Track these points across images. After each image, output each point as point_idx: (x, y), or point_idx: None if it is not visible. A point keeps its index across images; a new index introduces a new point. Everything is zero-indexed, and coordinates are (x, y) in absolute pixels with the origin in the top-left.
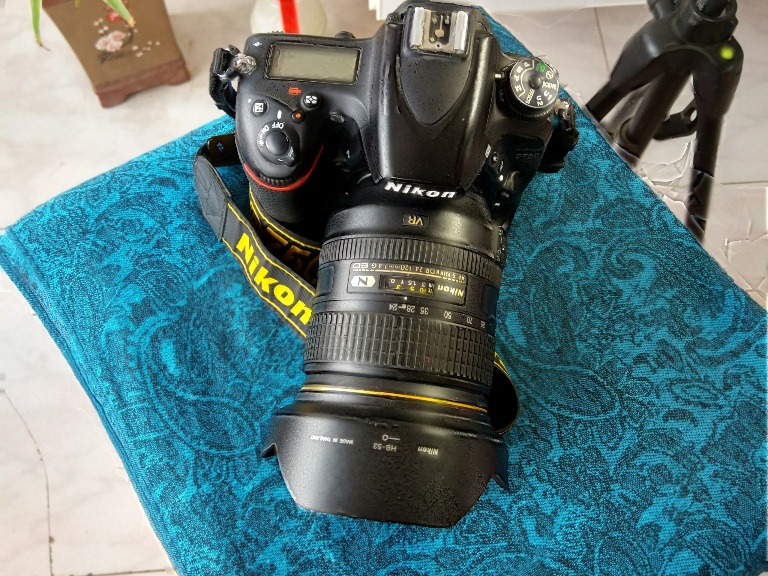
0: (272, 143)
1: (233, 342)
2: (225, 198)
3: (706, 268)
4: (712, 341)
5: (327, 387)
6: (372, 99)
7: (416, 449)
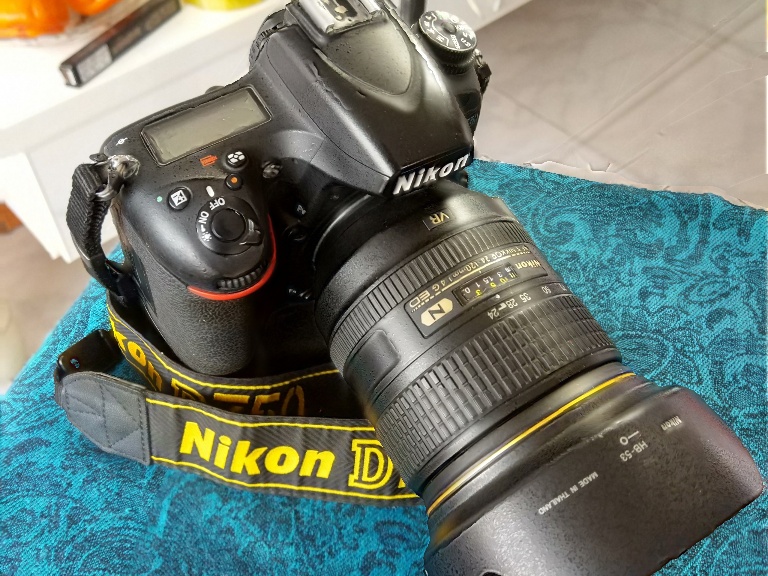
0: (221, 229)
1: (256, 561)
2: (139, 394)
3: (619, 193)
4: (678, 244)
5: (488, 457)
6: (311, 114)
7: (661, 430)
